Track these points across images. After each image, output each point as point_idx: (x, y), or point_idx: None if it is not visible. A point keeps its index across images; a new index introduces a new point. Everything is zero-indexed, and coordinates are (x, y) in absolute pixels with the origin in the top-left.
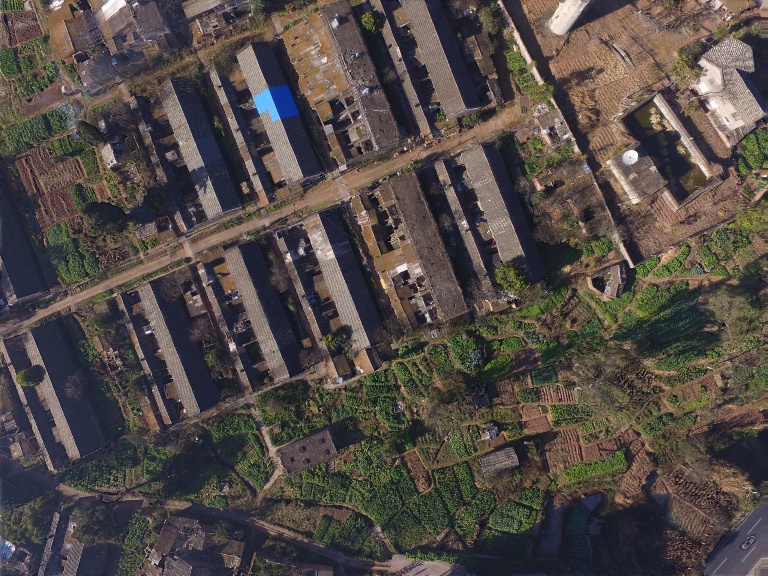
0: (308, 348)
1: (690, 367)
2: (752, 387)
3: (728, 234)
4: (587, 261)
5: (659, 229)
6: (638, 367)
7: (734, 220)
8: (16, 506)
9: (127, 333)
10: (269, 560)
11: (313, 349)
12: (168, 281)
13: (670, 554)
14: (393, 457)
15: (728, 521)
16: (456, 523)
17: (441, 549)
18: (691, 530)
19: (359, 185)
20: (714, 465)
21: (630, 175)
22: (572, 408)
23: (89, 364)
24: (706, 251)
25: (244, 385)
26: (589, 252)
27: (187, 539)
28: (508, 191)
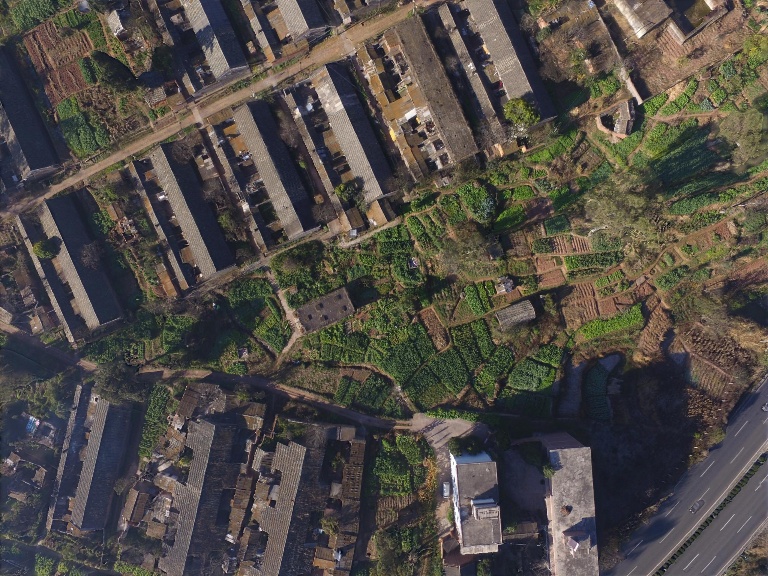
0: (321, 204)
1: (703, 213)
2: (766, 237)
3: (735, 67)
4: (595, 102)
5: (666, 64)
6: (651, 213)
7: (741, 49)
8: (38, 380)
9: (140, 203)
10: (291, 419)
11: (326, 206)
12: (179, 143)
13: (691, 412)
14: (410, 308)
15: (748, 376)
16: (475, 381)
17: (462, 408)
18: (711, 389)
19: (364, 39)
20: (731, 321)
21: (634, 5)
22: (586, 258)
23: (104, 237)
24: (714, 84)
25: (259, 245)
26: (597, 92)
27: (209, 405)
28: (513, 30)
